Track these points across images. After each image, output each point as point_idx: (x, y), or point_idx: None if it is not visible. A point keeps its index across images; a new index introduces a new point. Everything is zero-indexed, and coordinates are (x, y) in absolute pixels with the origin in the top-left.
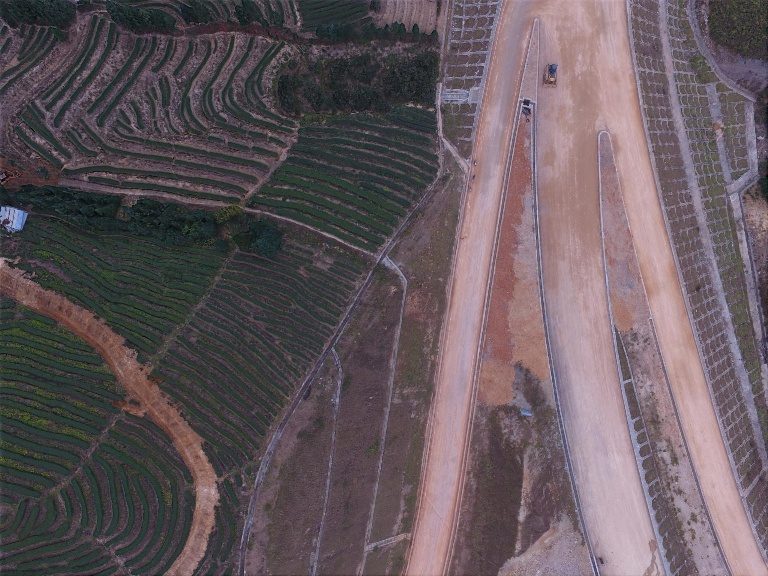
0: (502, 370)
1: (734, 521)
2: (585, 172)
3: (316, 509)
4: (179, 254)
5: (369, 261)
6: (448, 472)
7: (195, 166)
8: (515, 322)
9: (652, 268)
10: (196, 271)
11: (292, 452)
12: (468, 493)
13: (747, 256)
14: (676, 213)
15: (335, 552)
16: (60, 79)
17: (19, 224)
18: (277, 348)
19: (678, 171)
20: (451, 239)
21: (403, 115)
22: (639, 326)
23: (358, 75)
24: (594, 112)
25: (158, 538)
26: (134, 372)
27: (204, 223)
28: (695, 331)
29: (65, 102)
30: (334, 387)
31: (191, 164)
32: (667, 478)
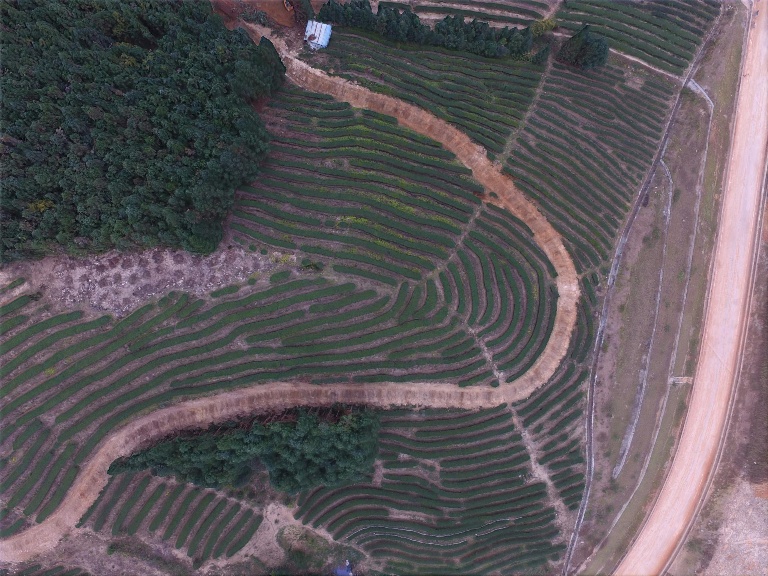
0: None
1: None
2: None
3: (647, 324)
4: None
5: (675, 84)
6: (730, 315)
7: None
8: None
9: None
10: (517, 83)
11: (638, 257)
12: (752, 335)
13: None
14: None
15: (653, 375)
16: None
17: (325, 40)
18: (611, 156)
19: None
20: (735, 75)
21: None
22: None
23: None
24: None
25: None
26: (487, 168)
27: None
28: None
29: None
30: (665, 199)
31: None
32: None
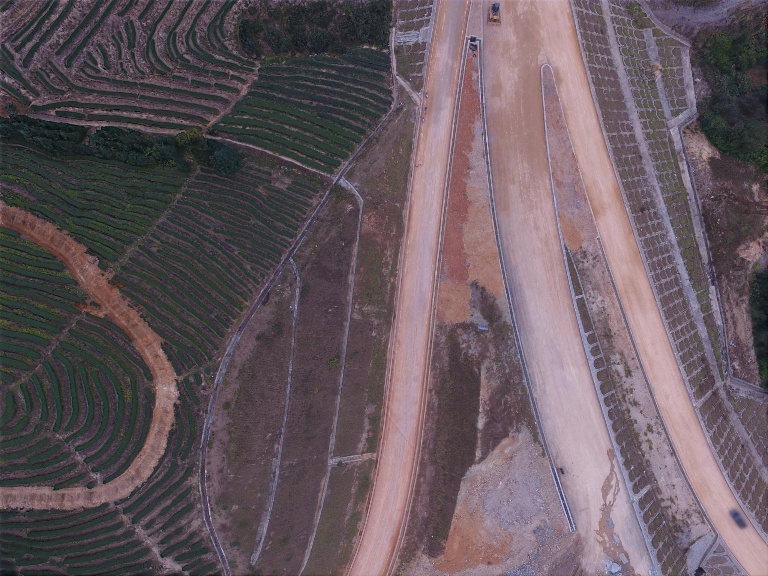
0: (459, 289)
1: (689, 431)
2: (530, 102)
3: (277, 414)
4: (142, 175)
5: (326, 182)
6: (411, 391)
7: (159, 100)
8: (470, 243)
9: (597, 190)
10: (158, 189)
11: (251, 354)
12: (431, 411)
13: (690, 185)
14: (618, 140)
15: (298, 461)
16: (29, 23)
17: None
18: (236, 258)
19: (618, 103)
20: (406, 167)
21: (358, 56)
22: (588, 244)
23: (315, 19)
24: (536, 47)
25: (118, 434)
26: (95, 277)
27: (166, 145)
28: (641, 248)
29: (34, 44)
30: (292, 295)
31: (155, 99)
32: (622, 390)
